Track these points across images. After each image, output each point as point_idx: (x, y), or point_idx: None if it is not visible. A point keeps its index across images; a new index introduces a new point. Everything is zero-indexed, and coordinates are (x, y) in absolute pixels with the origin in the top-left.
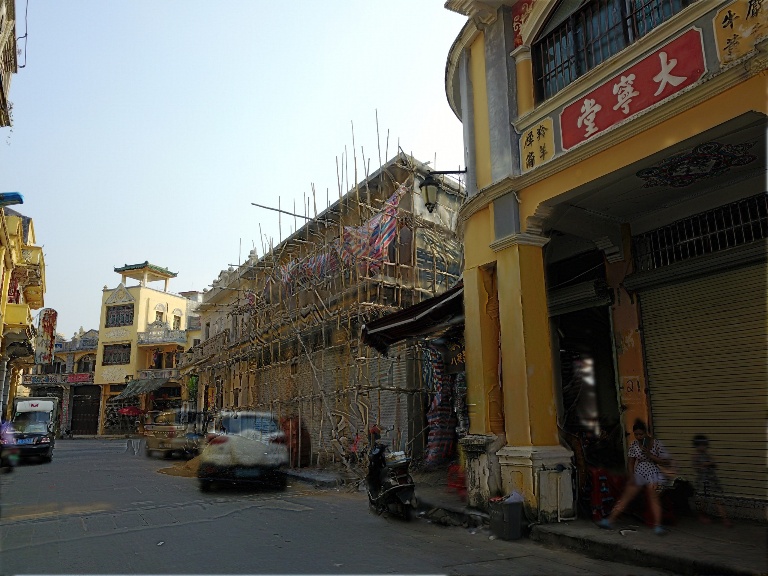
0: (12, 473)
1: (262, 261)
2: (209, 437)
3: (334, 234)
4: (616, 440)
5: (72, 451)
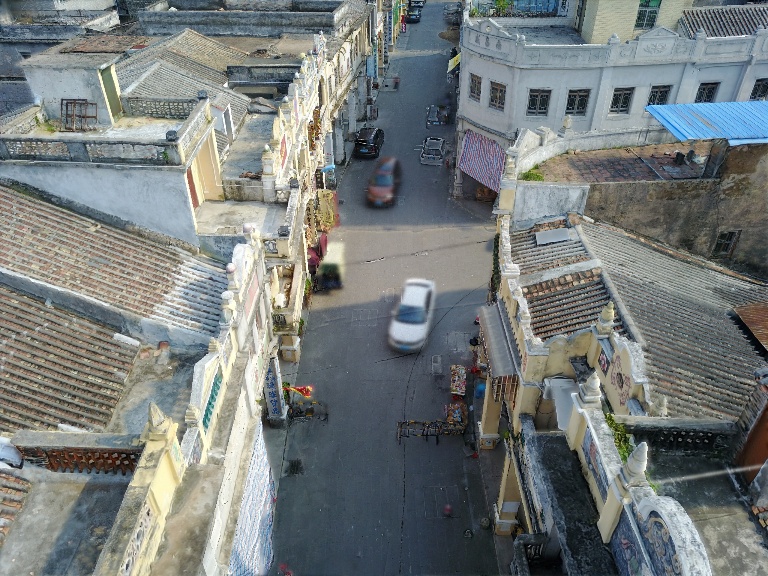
0: (410, 29)
1: None
2: None
3: None
4: None
5: (430, 8)
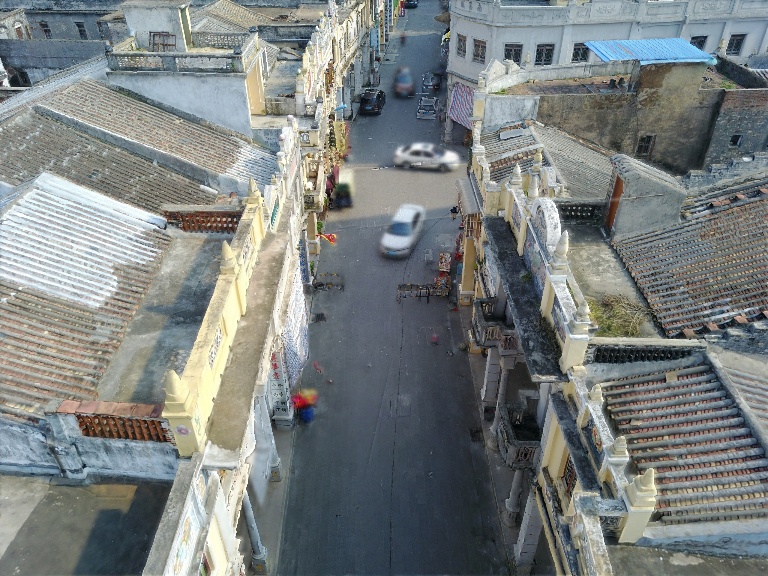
0: (409, 13)
1: None
2: None
3: None
4: None
5: None
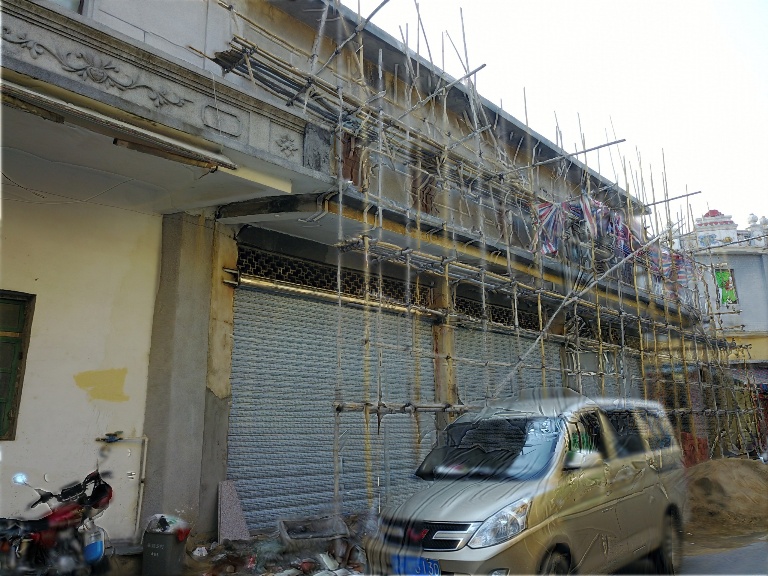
0: None
1: (410, 60)
2: (44, 543)
3: (552, 187)
4: (725, 447)
5: None
